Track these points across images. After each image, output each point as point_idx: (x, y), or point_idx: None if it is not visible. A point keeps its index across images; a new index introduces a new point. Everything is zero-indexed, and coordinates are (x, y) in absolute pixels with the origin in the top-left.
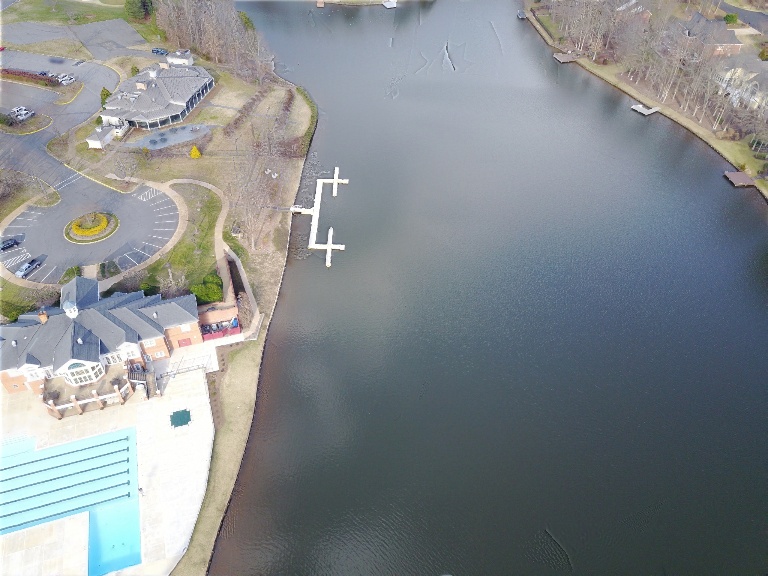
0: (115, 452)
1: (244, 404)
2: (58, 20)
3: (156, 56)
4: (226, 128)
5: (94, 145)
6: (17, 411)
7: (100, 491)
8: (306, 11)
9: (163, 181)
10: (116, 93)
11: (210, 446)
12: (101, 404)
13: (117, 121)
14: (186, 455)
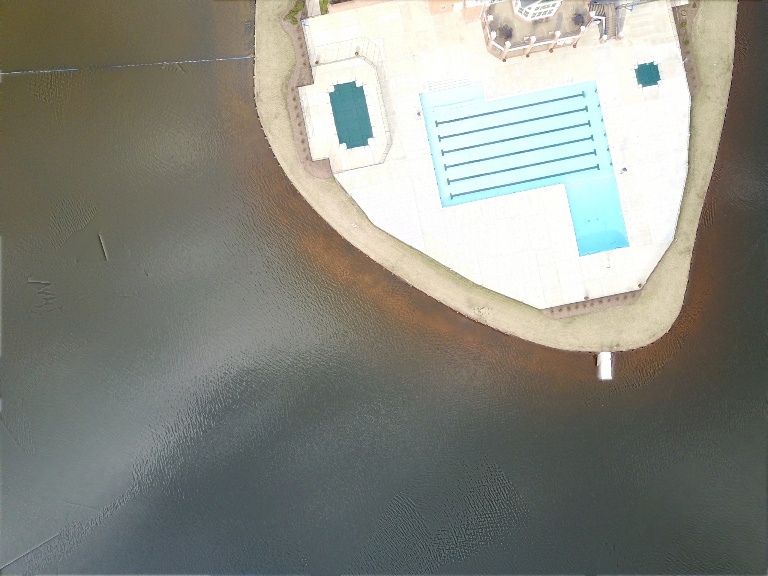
0: (573, 111)
1: (721, 60)
2: None
3: None
4: None
5: None
6: (449, 43)
7: (566, 159)
8: None
9: None
10: None
11: (687, 118)
12: (552, 45)
13: None
14: (660, 127)
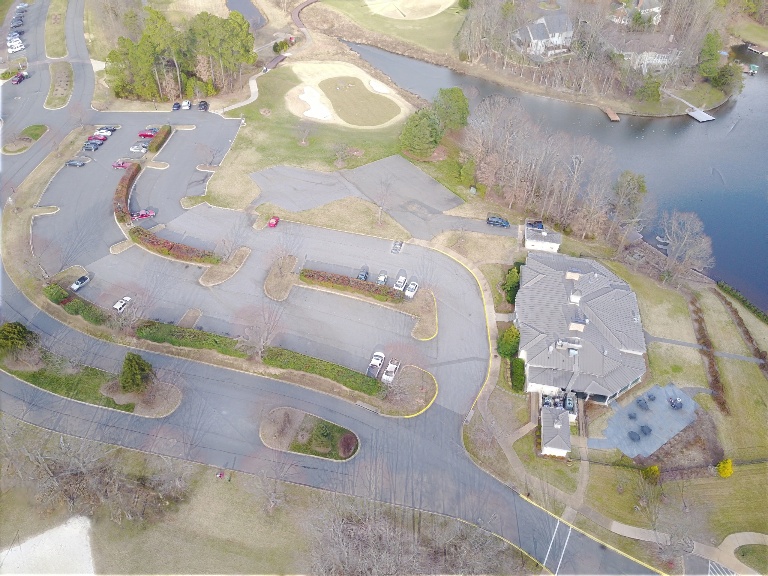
0: None
1: None
2: (320, 161)
3: (495, 229)
4: (719, 397)
5: (553, 451)
6: None
7: None
8: (588, 123)
9: (715, 541)
10: (528, 332)
11: None
12: None
13: (554, 390)
14: None
